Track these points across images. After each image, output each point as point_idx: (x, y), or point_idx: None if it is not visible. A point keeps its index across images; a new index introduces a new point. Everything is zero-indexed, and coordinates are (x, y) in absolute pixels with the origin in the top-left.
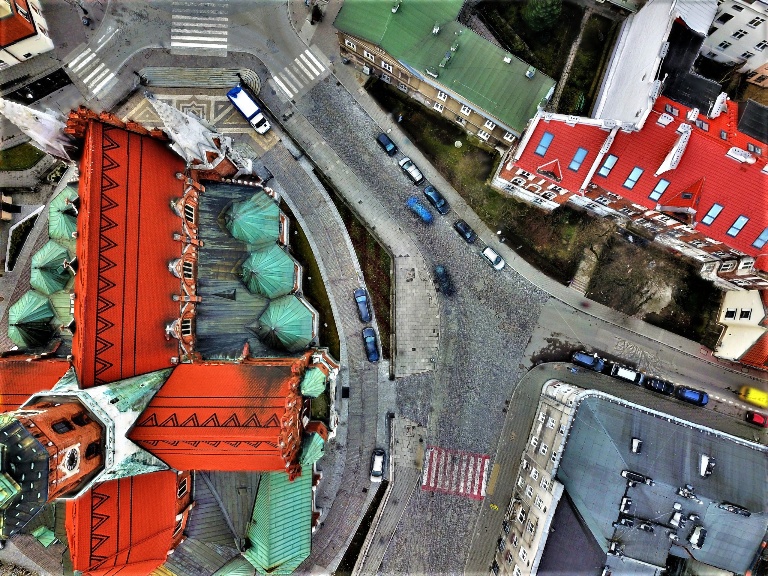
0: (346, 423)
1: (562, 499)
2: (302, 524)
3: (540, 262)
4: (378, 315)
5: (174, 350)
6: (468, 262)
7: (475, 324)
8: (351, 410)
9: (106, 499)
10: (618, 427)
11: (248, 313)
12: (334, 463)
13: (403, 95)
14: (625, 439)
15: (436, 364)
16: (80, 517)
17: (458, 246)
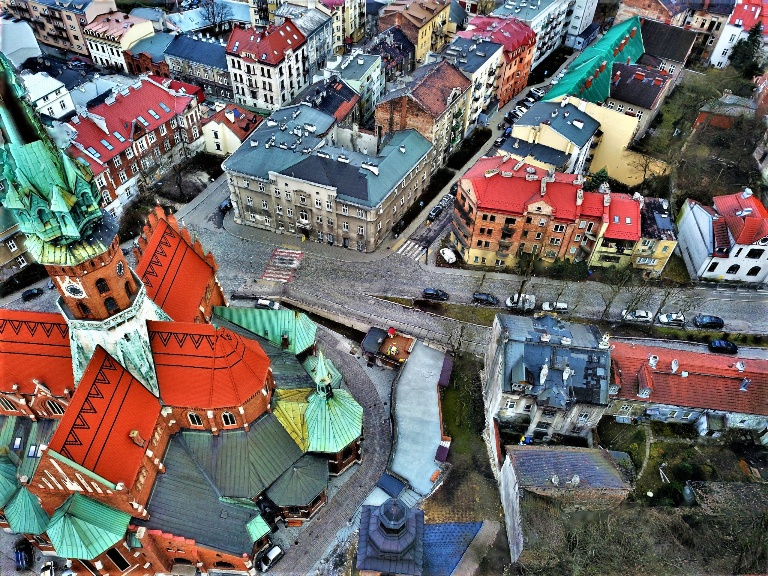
0: None
1: None
2: None
3: None
4: None
5: None
6: None
7: None
8: None
9: None
10: None
11: None
12: None
13: (1, 285)
14: None
15: None
16: None
17: (127, 260)
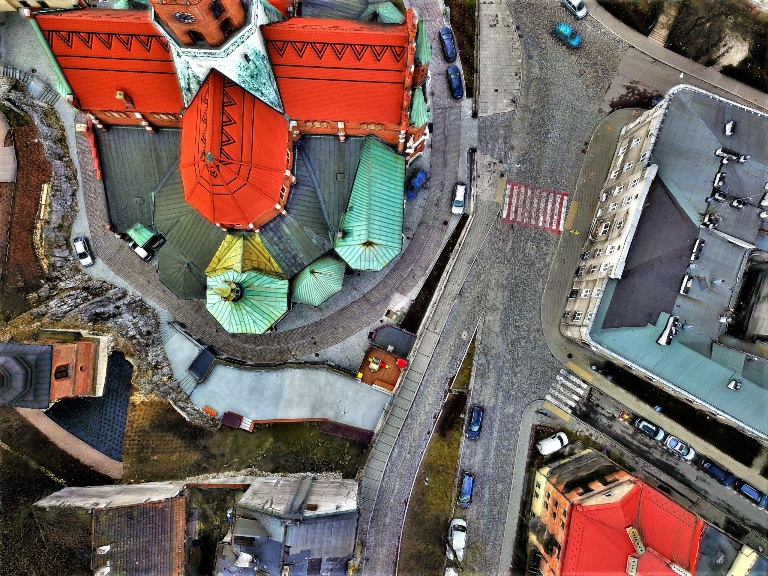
0: (429, 157)
1: (655, 181)
2: (395, 219)
3: (622, 8)
4: (462, 55)
5: (290, 2)
6: (550, 10)
7: (556, 69)
8: (434, 145)
9: (234, 104)
10: (711, 115)
11: (348, 11)
12: (416, 195)
13: None
14: (718, 125)
15: (518, 105)
16: (214, 104)
17: None
